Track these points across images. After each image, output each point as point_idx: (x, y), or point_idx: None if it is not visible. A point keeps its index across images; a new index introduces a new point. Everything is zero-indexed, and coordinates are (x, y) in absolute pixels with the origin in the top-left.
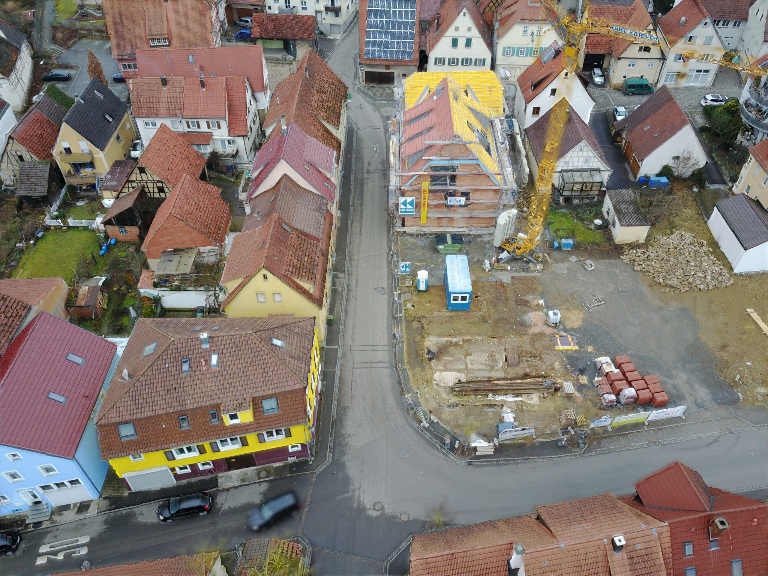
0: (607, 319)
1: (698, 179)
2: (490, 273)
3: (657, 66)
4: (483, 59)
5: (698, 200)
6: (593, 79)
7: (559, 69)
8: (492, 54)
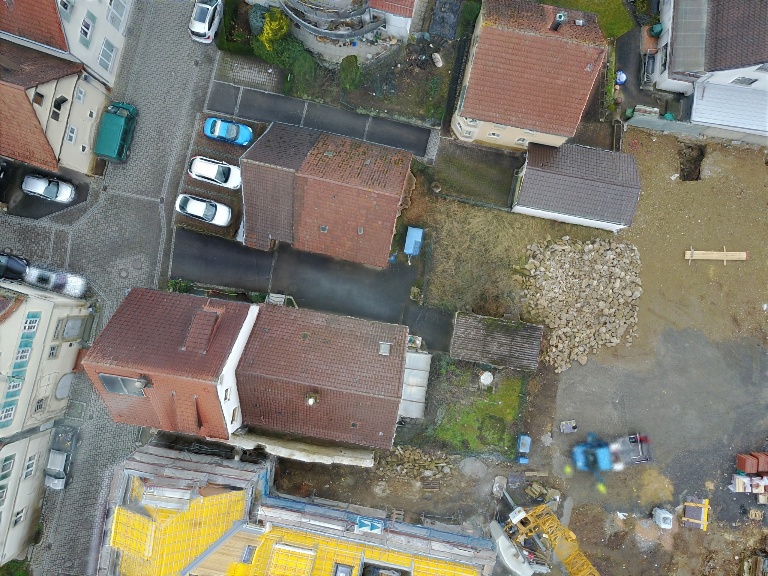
0: (667, 444)
1: (416, 172)
2: (554, 567)
3: (87, 84)
4: (4, 462)
5: (460, 197)
6: (57, 203)
7: (204, 395)
8: (2, 447)
